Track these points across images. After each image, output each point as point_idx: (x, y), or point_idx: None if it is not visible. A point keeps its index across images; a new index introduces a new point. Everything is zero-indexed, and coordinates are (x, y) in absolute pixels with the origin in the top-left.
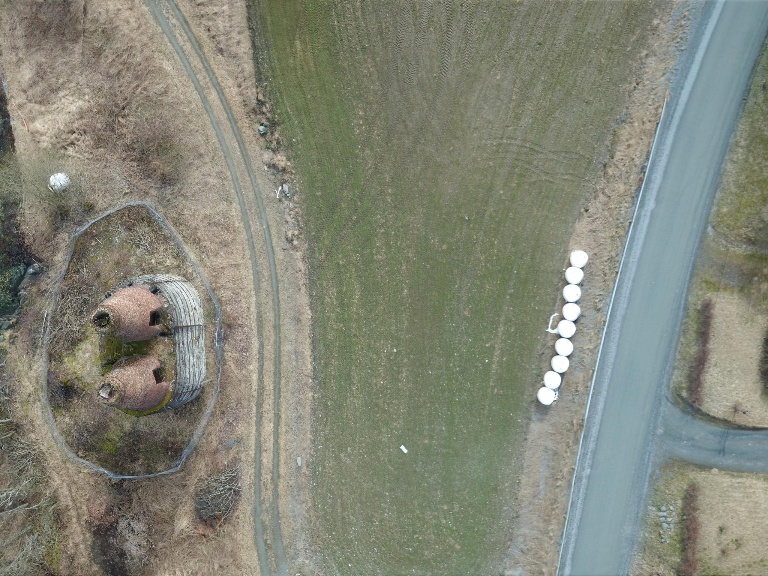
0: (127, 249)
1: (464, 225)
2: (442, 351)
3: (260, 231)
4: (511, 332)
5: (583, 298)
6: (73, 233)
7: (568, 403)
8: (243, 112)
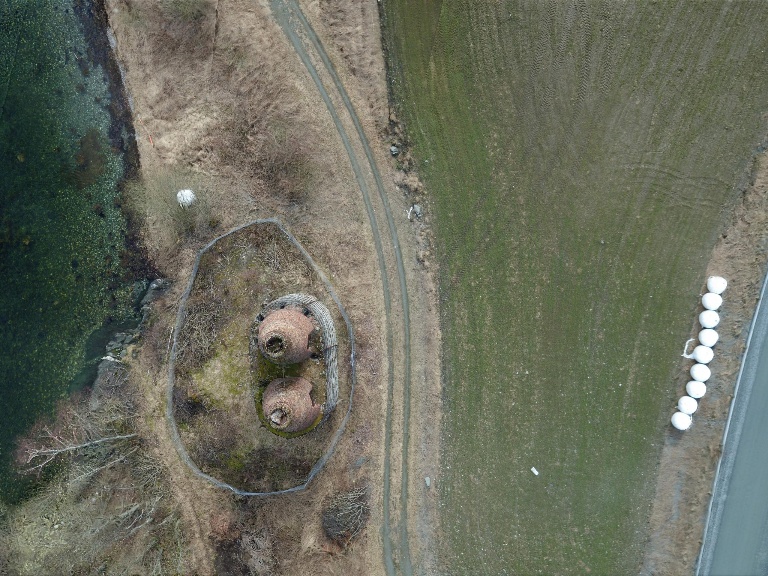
0: (256, 267)
1: (600, 249)
2: (575, 374)
3: (391, 251)
4: (646, 356)
5: (720, 324)
6: (198, 249)
7: (703, 428)
8: (375, 132)
